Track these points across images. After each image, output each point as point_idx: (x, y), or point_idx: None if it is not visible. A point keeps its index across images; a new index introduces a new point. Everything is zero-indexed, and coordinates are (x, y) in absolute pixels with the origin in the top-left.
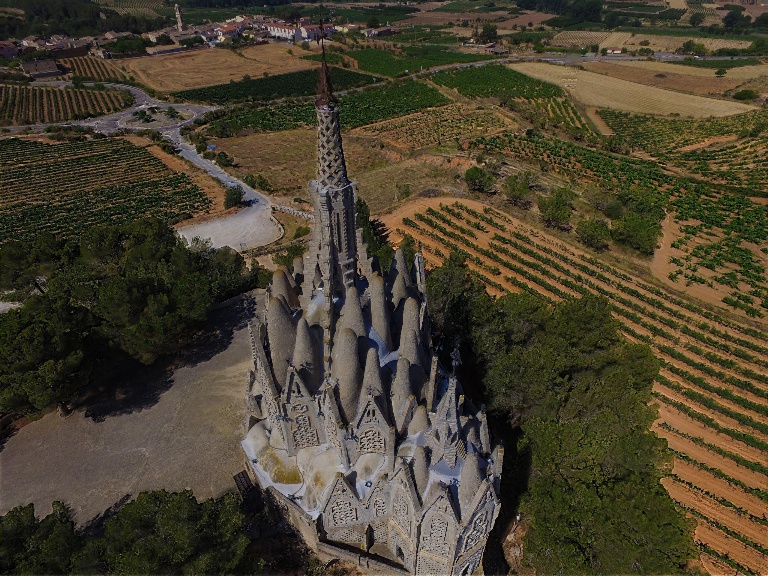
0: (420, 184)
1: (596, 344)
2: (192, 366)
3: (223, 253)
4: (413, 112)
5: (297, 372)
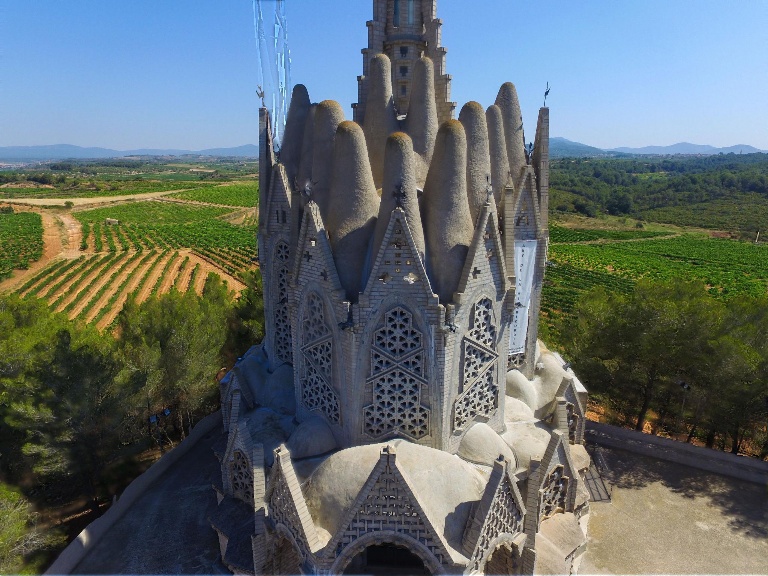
0: None
1: None
2: None
3: None
4: None
5: None
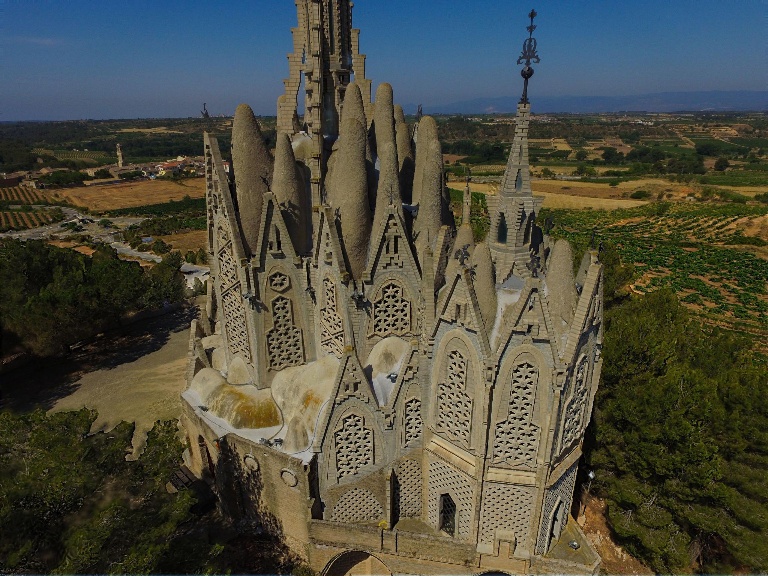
0: None
1: (613, 294)
2: (109, 368)
3: (159, 267)
4: None
5: (277, 204)
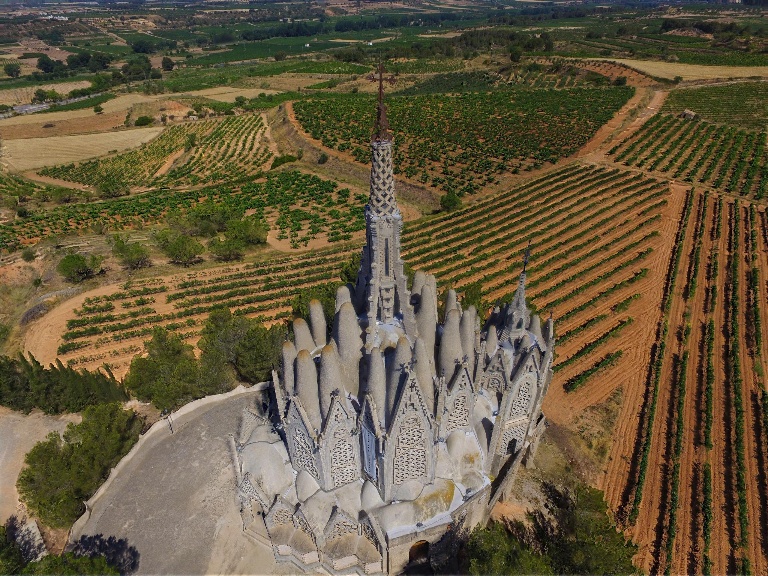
0: None
1: None
2: None
3: None
4: None
5: None
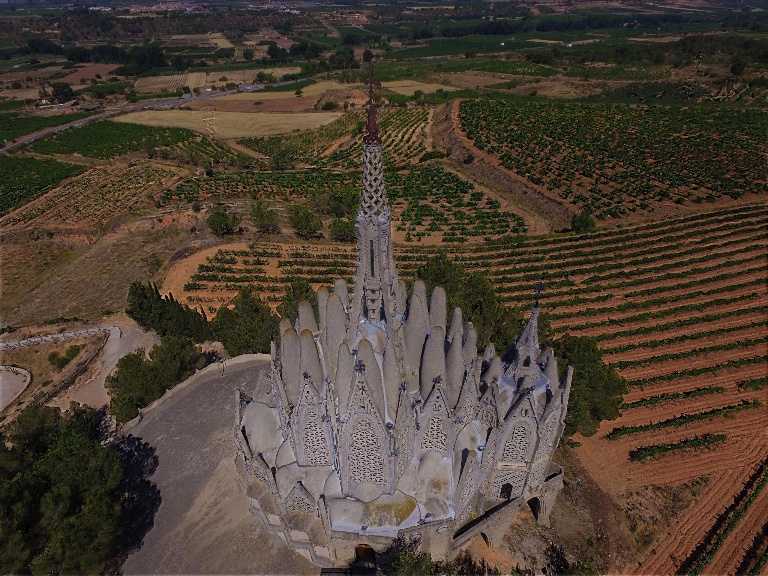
0: (147, 253)
1: None
2: (138, 548)
3: (33, 416)
4: (50, 189)
5: None
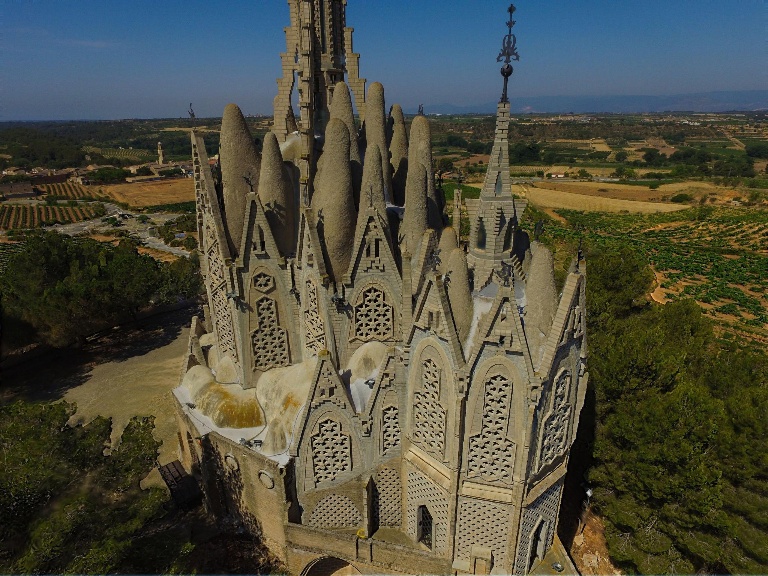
0: None
1: (630, 303)
2: (121, 360)
3: (178, 263)
4: None
5: (261, 204)
